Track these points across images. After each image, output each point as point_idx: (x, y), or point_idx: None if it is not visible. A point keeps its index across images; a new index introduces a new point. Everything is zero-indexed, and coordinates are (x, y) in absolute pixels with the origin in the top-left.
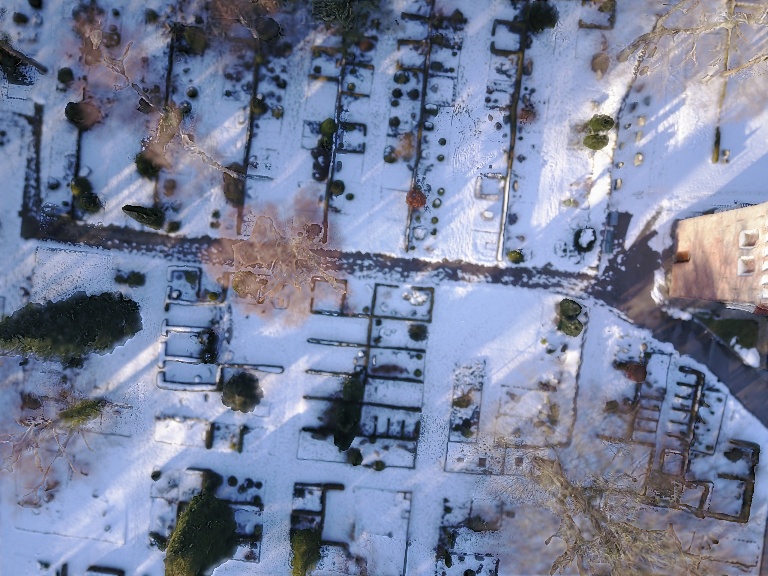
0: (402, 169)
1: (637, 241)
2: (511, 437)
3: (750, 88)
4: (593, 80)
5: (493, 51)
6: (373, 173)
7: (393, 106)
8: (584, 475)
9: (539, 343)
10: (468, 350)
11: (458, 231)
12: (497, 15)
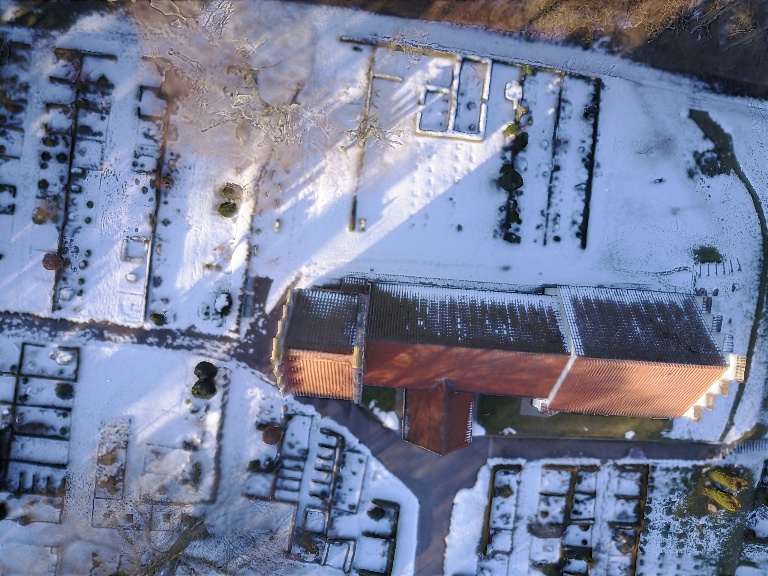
0: (51, 231)
1: (278, 305)
2: (156, 494)
3: (388, 158)
4: (237, 147)
5: (140, 116)
6: (23, 234)
7: (42, 169)
8: (231, 531)
9: (183, 403)
10: (113, 409)
11: (105, 292)
12: (144, 81)
